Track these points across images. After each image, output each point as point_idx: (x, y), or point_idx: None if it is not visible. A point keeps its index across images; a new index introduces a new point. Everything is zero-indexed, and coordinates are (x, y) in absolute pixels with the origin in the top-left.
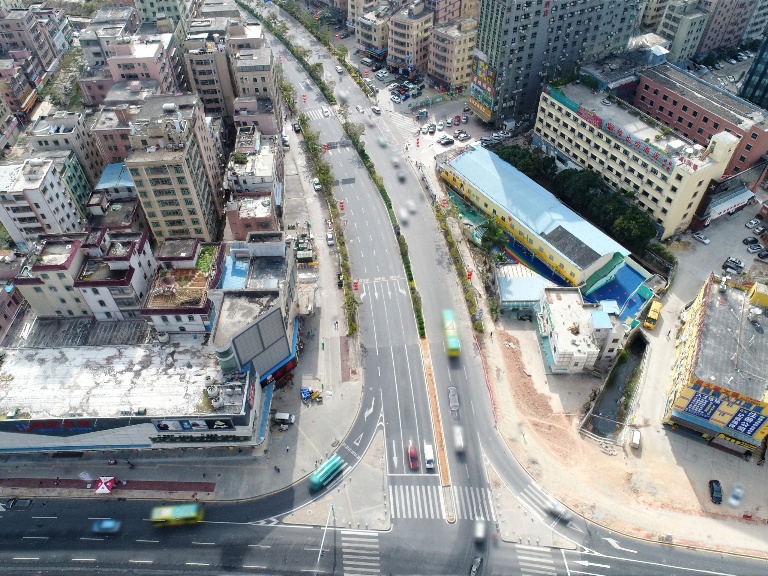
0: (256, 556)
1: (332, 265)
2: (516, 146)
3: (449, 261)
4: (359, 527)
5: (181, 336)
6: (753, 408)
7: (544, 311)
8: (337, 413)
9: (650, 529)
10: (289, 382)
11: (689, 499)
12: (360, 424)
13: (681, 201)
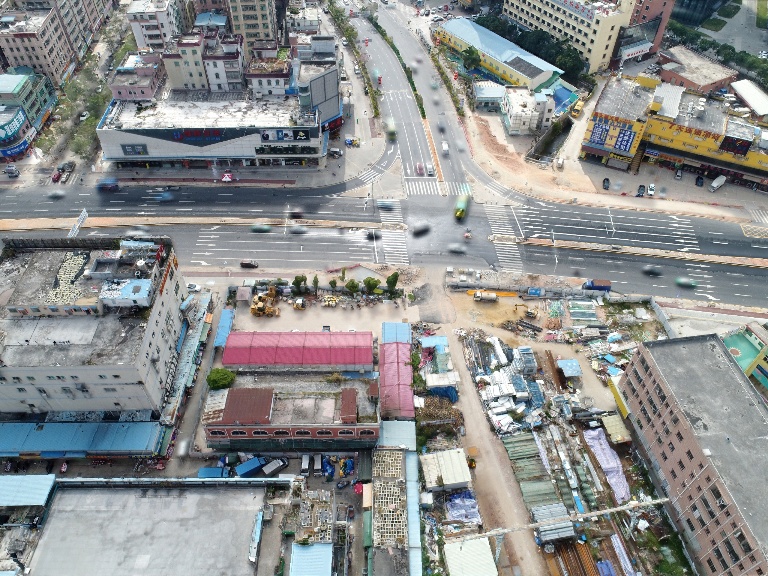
0: (326, 209)
1: (360, 84)
2: (489, 16)
3: (441, 83)
4: (388, 198)
5: (269, 97)
6: (627, 127)
7: (505, 100)
8: (370, 151)
9: (565, 198)
10: (337, 137)
11: (590, 188)
12: (385, 157)
13: (600, 41)
